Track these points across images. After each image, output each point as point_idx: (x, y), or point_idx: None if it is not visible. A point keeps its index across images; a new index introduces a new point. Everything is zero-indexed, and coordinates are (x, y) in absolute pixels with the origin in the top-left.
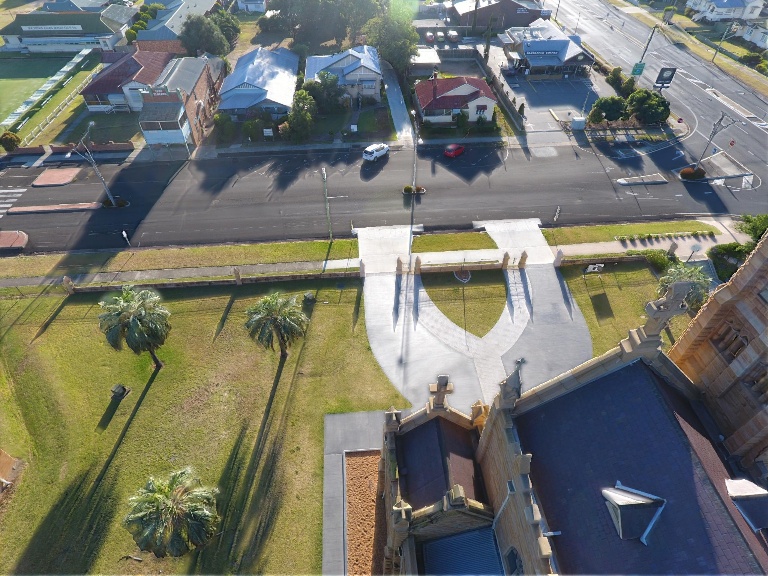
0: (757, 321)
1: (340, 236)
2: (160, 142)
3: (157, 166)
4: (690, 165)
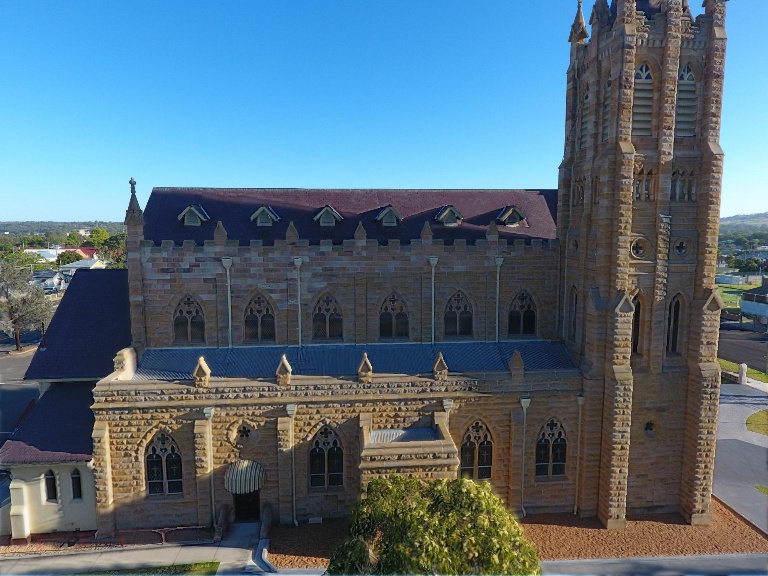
0: None
1: None
2: (750, 312)
3: None
4: None
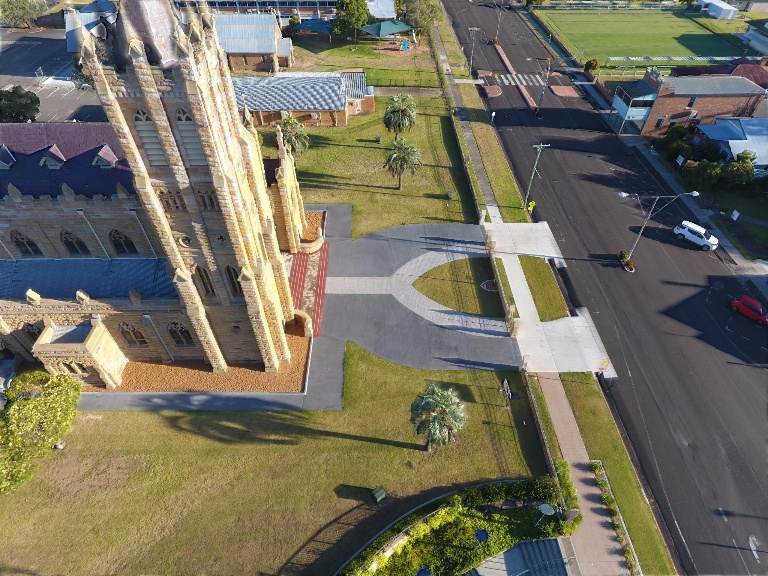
0: None
1: (534, 215)
2: None
3: (599, 123)
4: None
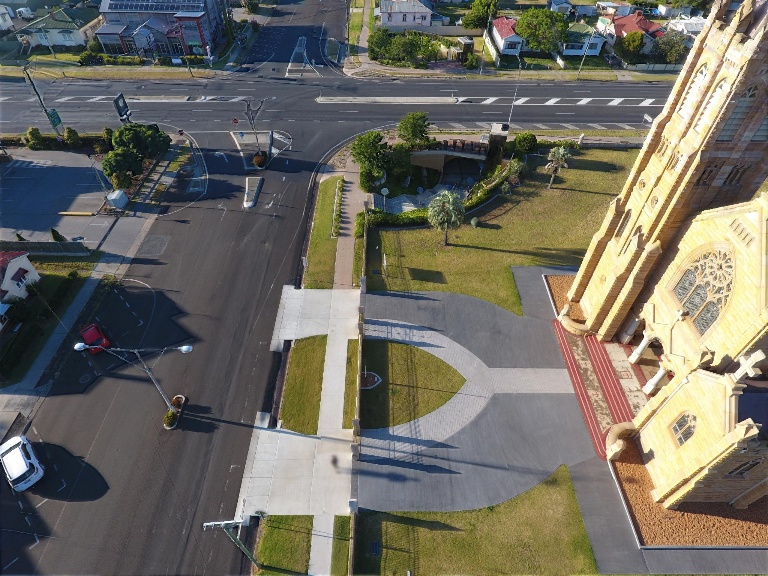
0: (722, 153)
1: None
2: None
3: None
4: (243, 156)
